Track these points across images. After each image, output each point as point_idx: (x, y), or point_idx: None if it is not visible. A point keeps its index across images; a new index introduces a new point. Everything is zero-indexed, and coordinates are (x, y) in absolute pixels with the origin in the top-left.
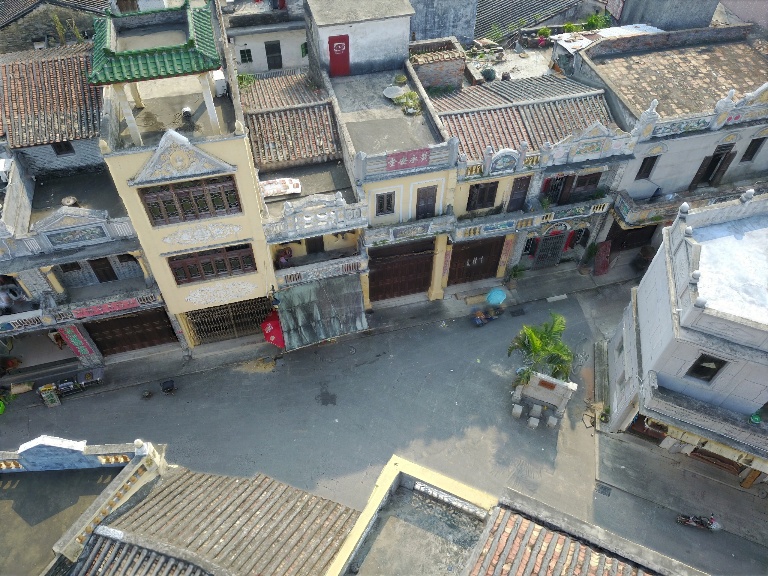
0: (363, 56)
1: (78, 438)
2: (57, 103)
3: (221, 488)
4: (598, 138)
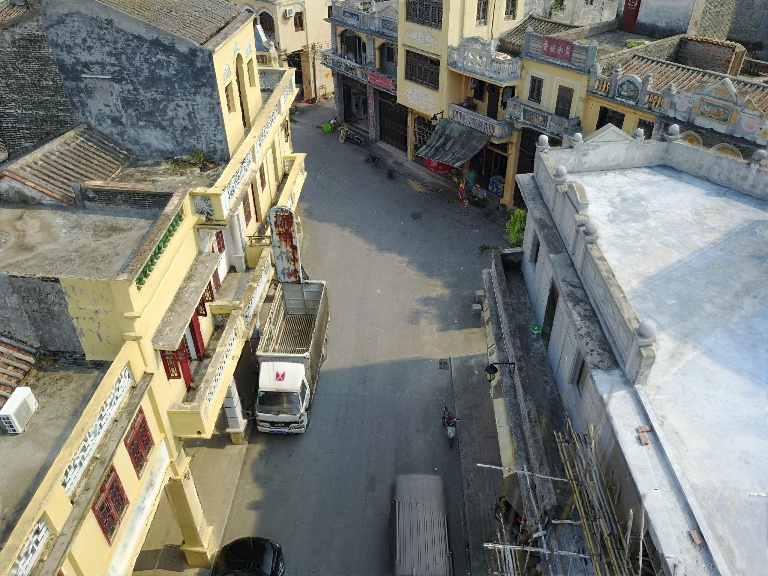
0: (649, 18)
1: (327, 153)
2: None
3: None
4: (724, 102)
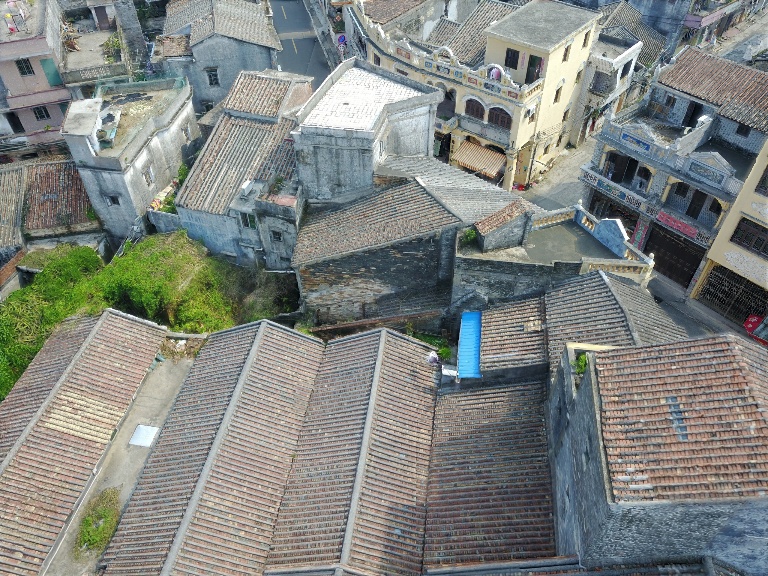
0: None
1: None
2: (766, 106)
3: (661, 314)
4: None
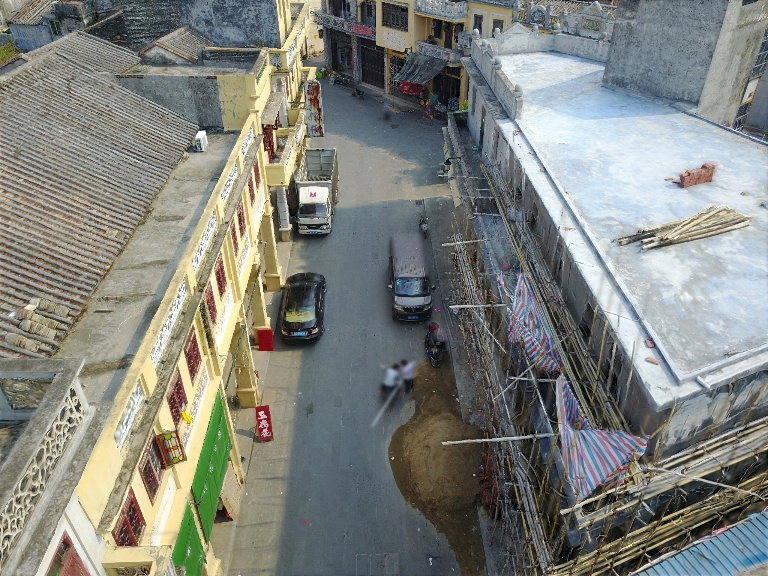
0: None
1: None
2: None
3: None
4: (596, 17)
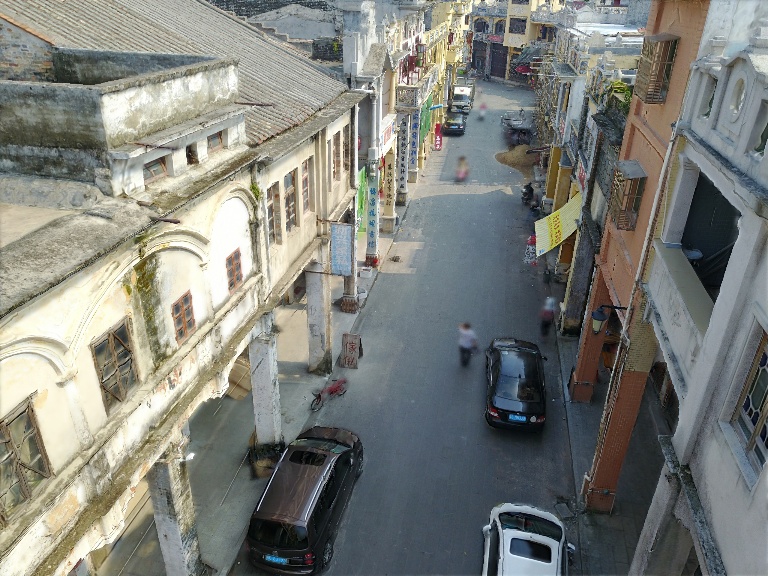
0: (625, 2)
1: None
2: None
3: None
4: None
